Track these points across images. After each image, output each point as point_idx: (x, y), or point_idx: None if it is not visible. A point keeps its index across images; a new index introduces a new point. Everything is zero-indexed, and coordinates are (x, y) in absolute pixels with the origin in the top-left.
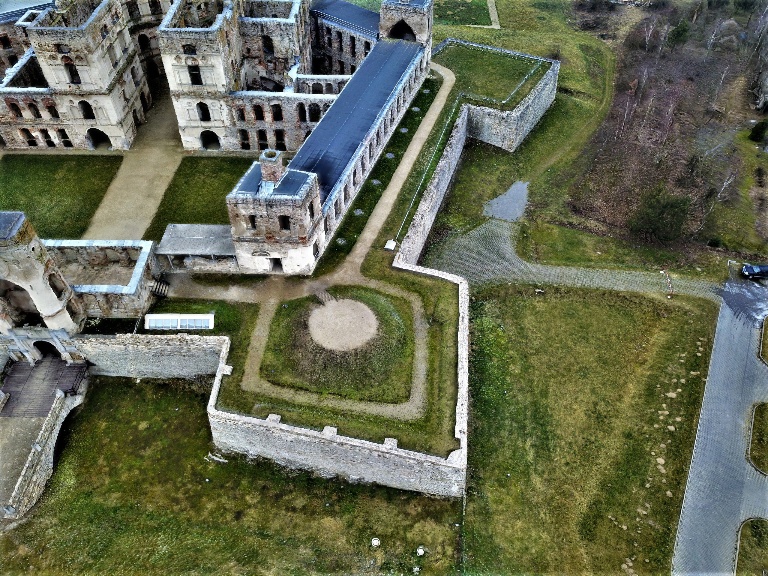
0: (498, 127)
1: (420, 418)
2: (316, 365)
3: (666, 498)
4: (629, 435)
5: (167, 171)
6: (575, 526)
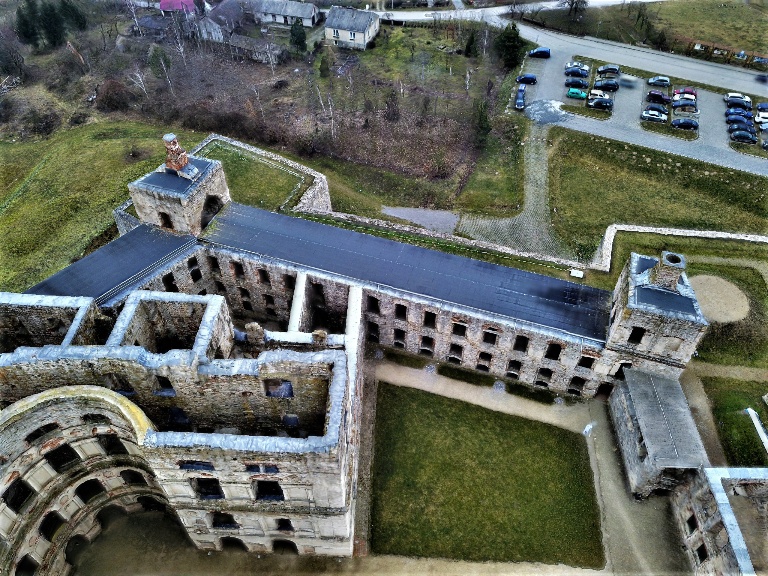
0: (321, 199)
1: (767, 262)
2: (762, 321)
3: (736, 175)
4: (686, 185)
5: (417, 573)
6: (766, 220)
